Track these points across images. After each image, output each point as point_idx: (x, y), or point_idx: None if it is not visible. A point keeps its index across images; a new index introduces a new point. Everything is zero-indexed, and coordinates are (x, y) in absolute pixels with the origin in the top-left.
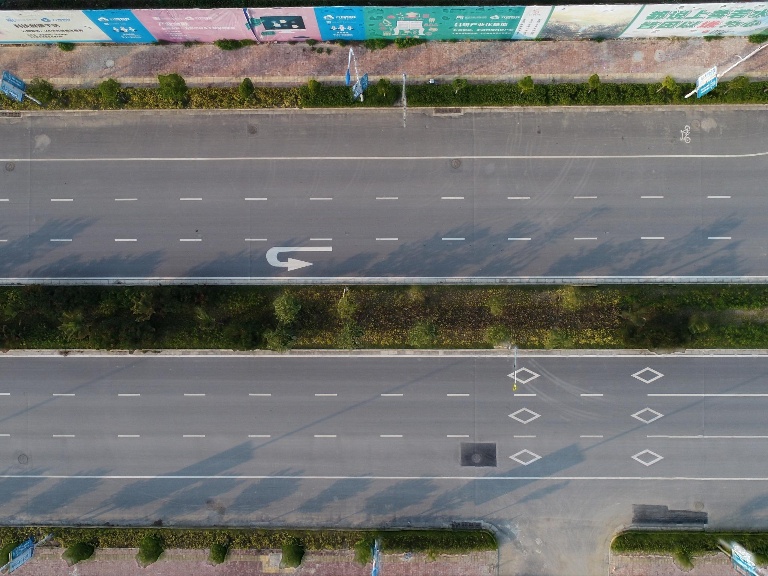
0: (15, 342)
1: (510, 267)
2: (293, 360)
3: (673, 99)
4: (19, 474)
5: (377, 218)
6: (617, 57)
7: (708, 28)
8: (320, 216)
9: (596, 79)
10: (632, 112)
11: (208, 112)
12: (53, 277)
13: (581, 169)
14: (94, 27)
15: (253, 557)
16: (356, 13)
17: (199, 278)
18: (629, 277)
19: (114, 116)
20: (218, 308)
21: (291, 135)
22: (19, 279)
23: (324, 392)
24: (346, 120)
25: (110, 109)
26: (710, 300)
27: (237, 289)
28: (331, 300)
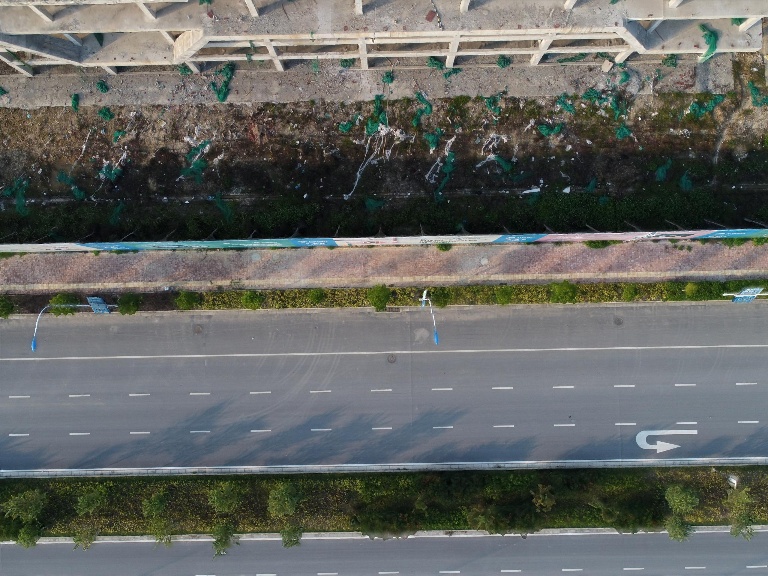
0: (415, 529)
1: None
2: (664, 536)
3: None
4: None
5: (738, 402)
6: None
7: None
8: (685, 401)
9: None
10: None
11: (576, 305)
12: (437, 462)
13: None
14: (491, 239)
15: None
16: (750, 232)
17: (574, 461)
18: None
19: (488, 310)
20: (595, 490)
21: (655, 326)
22: (405, 465)
23: (693, 565)
24: (705, 311)
25: (486, 304)
26: None
27: (611, 471)
28: (700, 481)
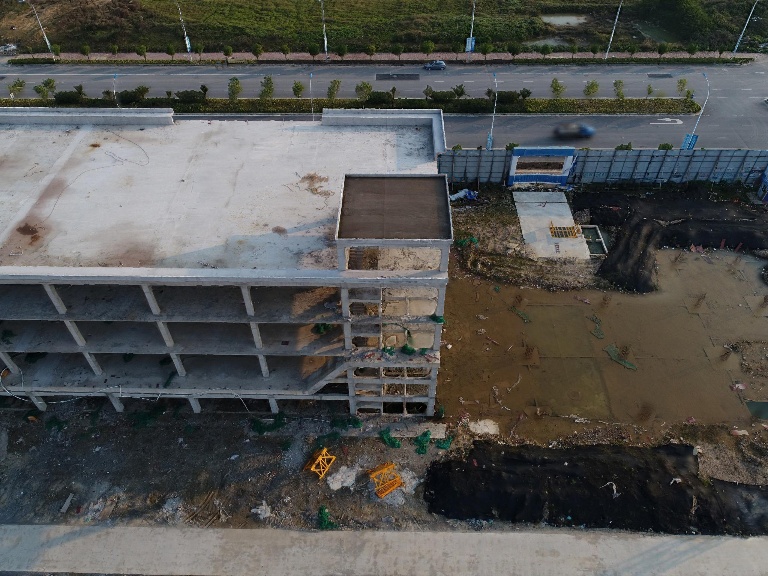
0: None
1: None
2: None
3: None
4: None
5: None
6: None
7: None
8: None
9: None
10: None
11: None
12: None
13: None
14: None
15: (109, 59)
16: None
17: None
18: None
19: None
20: None
21: None
22: None
23: None
24: None
25: None
26: None
27: None
28: None
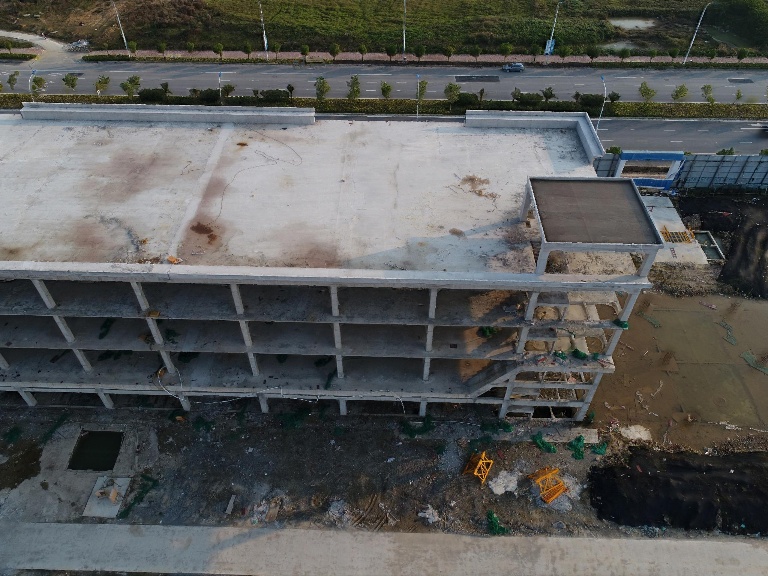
0: None
1: None
2: None
3: None
4: None
5: None
6: None
7: None
8: None
9: None
10: None
11: None
12: None
13: None
14: None
15: None
16: None
17: None
18: None
19: None
20: None
21: None
22: None
23: None
24: None
25: None
26: None
27: None
28: None
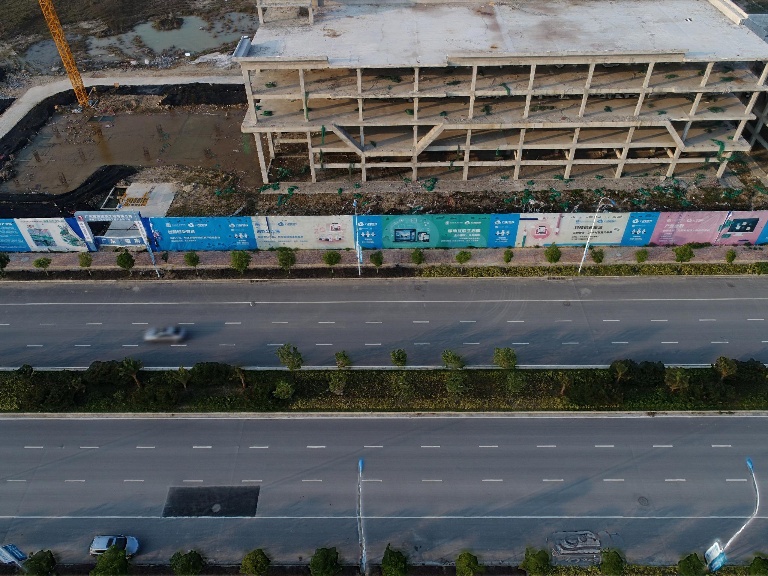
0: (621, 397)
1: None
2: None
3: None
4: (644, 515)
5: None
6: None
7: None
8: None
9: None
10: None
11: (695, 277)
12: None
13: None
14: (622, 229)
15: None
16: None
17: None
18: None
19: (631, 279)
20: None
21: (760, 288)
22: (596, 366)
23: None
24: None
25: (628, 275)
26: None
27: None
28: None
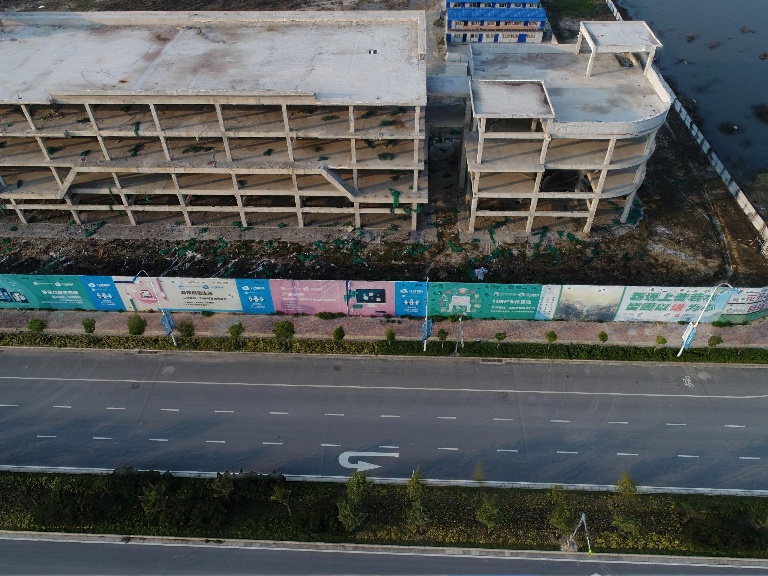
0: (88, 518)
1: (563, 475)
2: (356, 556)
3: (669, 357)
4: None
5: (438, 432)
6: (616, 332)
7: (678, 312)
8: (389, 429)
9: (604, 334)
10: (639, 366)
11: (304, 356)
12: (141, 469)
13: (609, 402)
14: (236, 296)
15: None
16: (424, 288)
17: None
18: (678, 488)
19: (230, 356)
20: None
21: (368, 372)
22: (109, 470)
23: None
24: (412, 364)
25: (228, 351)
26: (764, 509)
27: None
28: (397, 497)
